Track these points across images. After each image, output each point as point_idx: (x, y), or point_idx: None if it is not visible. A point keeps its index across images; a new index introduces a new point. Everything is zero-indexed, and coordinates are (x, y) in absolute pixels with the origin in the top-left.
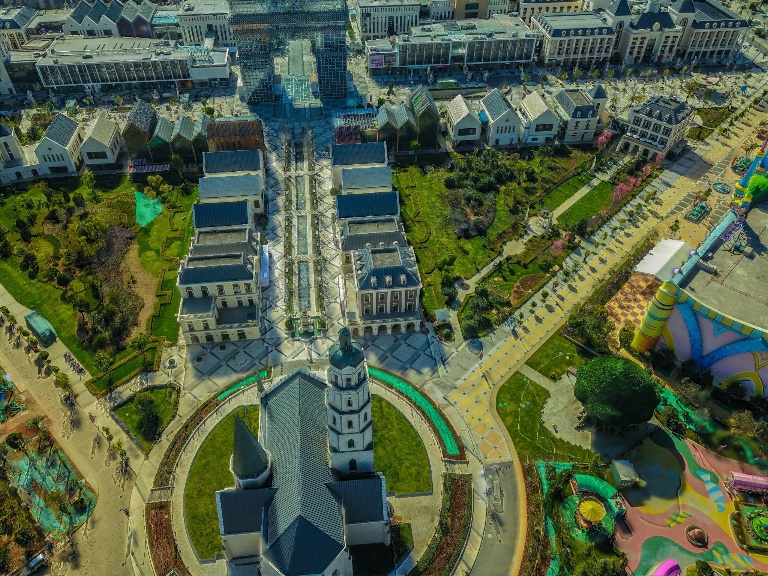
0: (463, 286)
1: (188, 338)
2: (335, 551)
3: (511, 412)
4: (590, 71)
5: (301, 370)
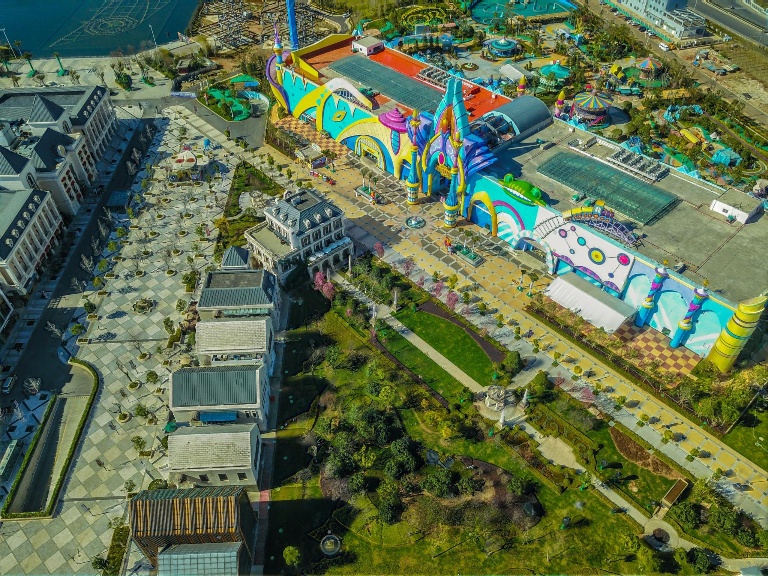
0: (664, 538)
1: None
2: None
3: None
4: (96, 251)
5: None
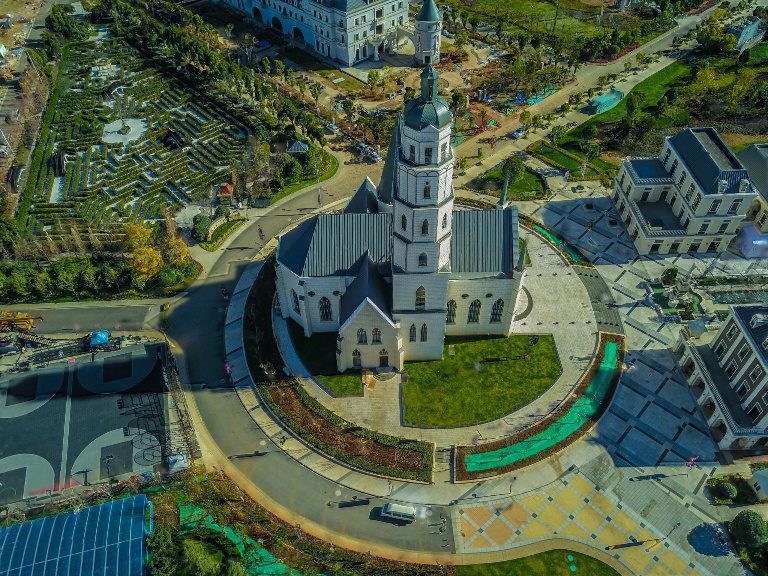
0: None
1: (615, 190)
2: (296, 268)
3: (556, 573)
4: None
5: (515, 210)
